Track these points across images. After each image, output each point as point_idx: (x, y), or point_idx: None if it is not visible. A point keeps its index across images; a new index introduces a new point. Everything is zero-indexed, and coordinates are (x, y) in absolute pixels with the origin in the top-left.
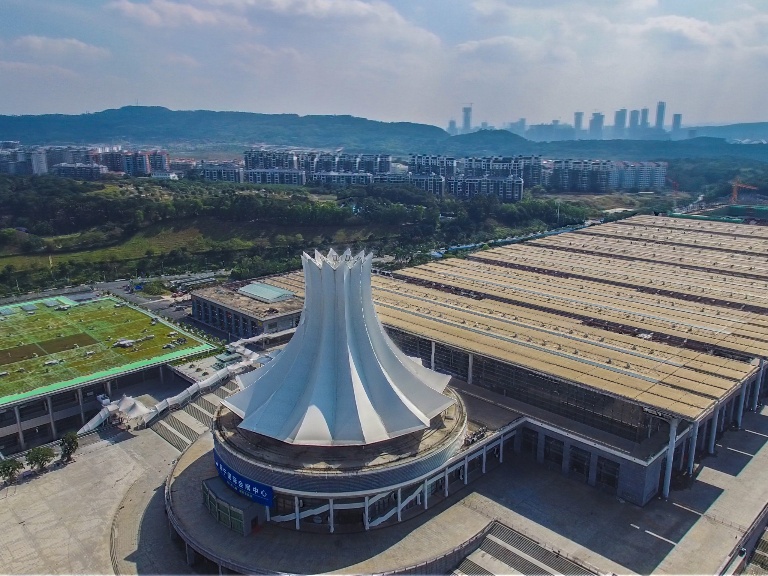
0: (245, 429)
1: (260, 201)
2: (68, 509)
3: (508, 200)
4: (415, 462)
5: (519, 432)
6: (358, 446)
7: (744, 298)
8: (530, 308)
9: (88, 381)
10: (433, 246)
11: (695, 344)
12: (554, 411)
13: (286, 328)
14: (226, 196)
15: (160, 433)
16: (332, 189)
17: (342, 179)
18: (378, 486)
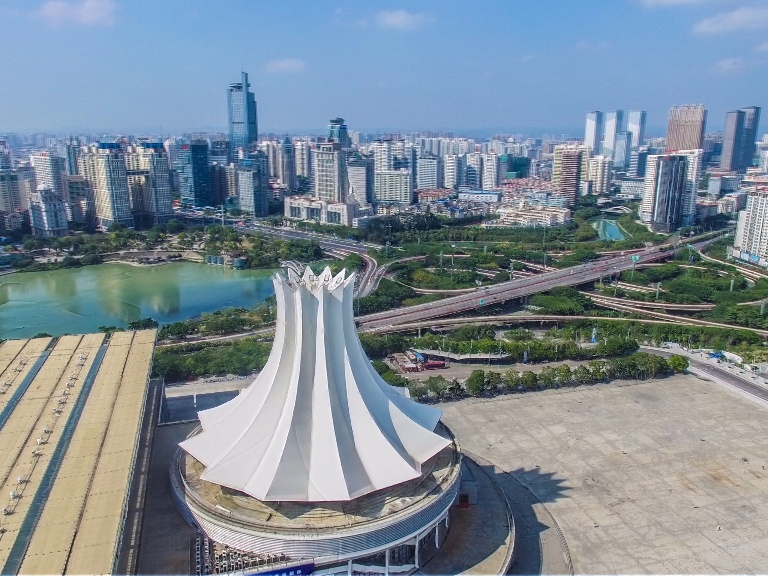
0: None
1: None
2: None
3: None
4: None
5: None
6: None
7: None
8: None
9: None
10: None
11: None
12: None
13: None
14: None
15: None
16: None
17: None
18: None
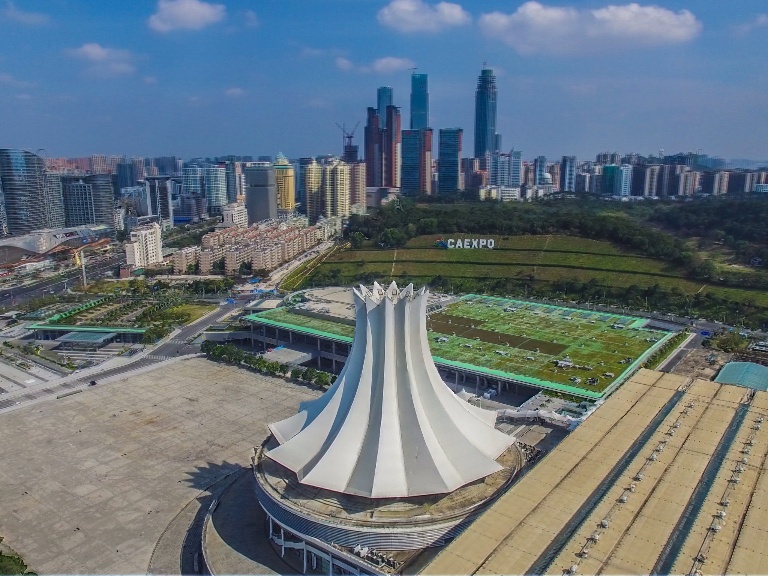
0: None
1: None
2: None
3: None
4: None
5: None
6: None
7: None
8: None
9: (478, 371)
10: None
11: None
12: None
13: None
14: None
15: None
16: None
17: None
18: None
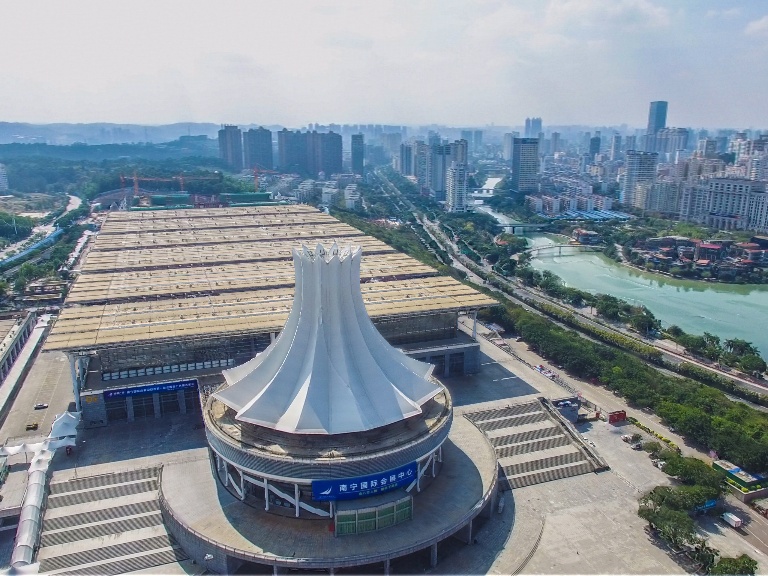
0: (369, 430)
1: None
2: None
3: None
4: None
5: None
6: None
7: None
8: (269, 289)
9: None
10: None
11: (401, 277)
12: (397, 344)
13: None
14: None
15: None
16: None
17: None
18: None
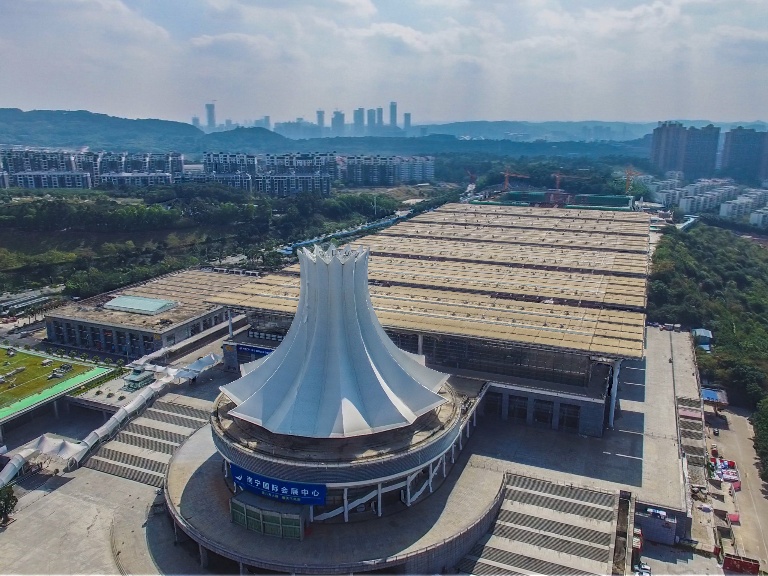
0: (281, 434)
1: (73, 207)
2: (50, 571)
3: (328, 195)
4: (446, 434)
5: (483, 397)
6: (396, 429)
7: (589, 265)
8: (438, 290)
9: None
10: (272, 244)
11: (588, 303)
12: (508, 374)
13: (183, 339)
14: (1, 204)
15: (101, 469)
16: (130, 191)
17: (137, 180)
18: (423, 462)
